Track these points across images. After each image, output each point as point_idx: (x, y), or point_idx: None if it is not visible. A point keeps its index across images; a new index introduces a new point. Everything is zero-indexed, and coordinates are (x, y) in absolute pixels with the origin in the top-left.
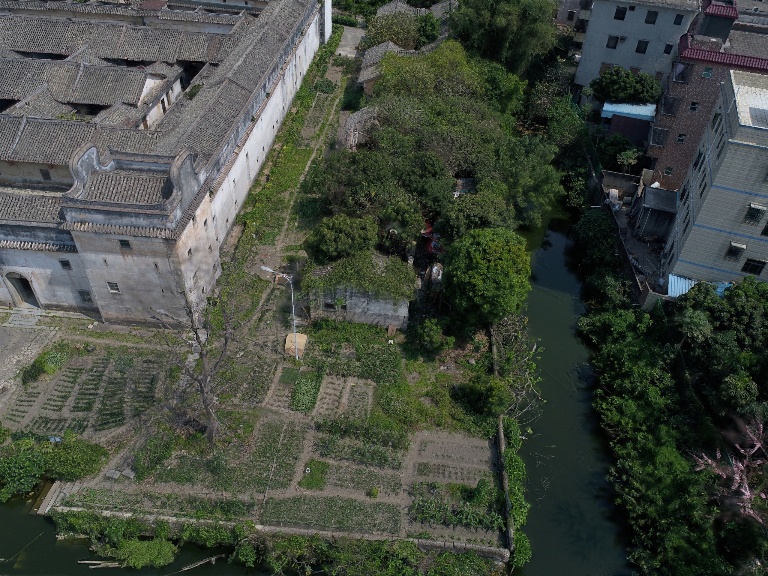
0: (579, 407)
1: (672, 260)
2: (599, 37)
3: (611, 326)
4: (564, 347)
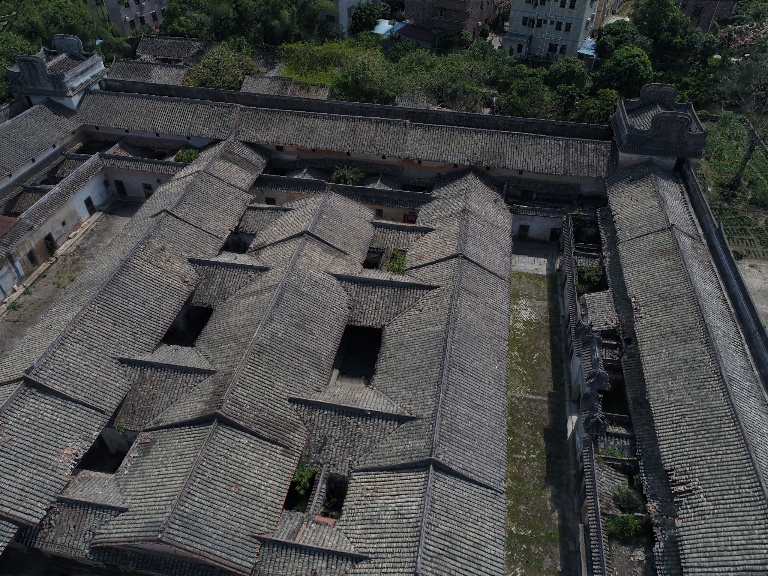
0: None
1: (568, 48)
2: None
3: None
4: None
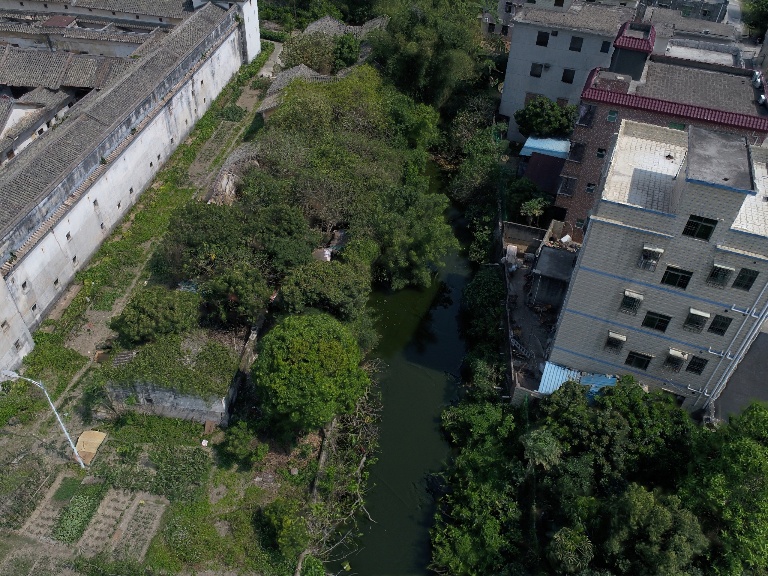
0: (416, 533)
1: (553, 343)
2: (522, 64)
3: (471, 426)
4: (420, 447)
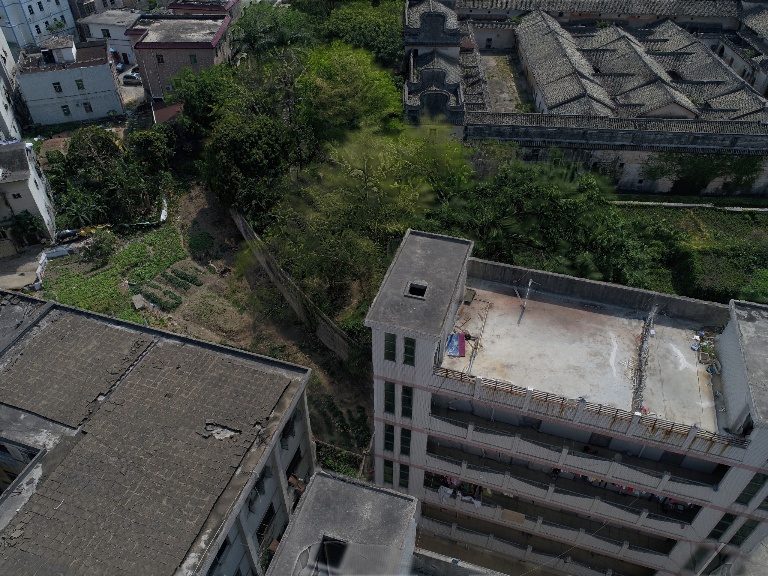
0: None
1: None
2: None
3: None
4: None
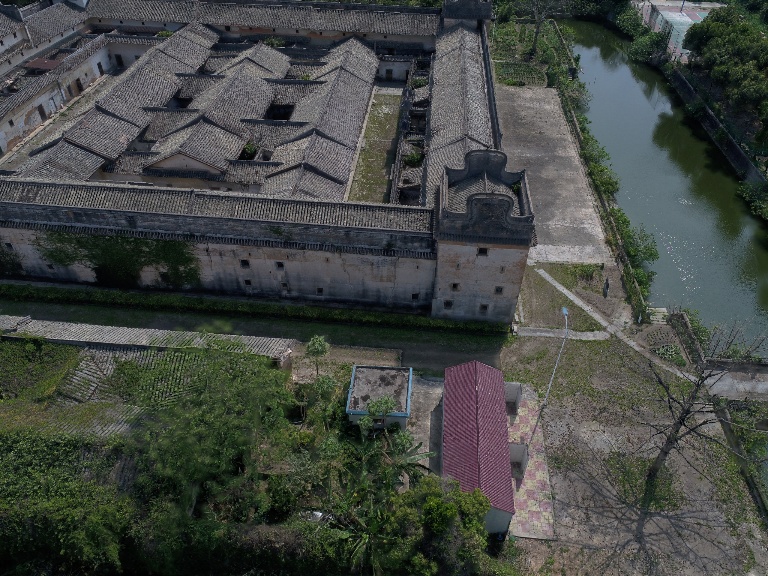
0: None
1: None
2: None
3: None
4: None
